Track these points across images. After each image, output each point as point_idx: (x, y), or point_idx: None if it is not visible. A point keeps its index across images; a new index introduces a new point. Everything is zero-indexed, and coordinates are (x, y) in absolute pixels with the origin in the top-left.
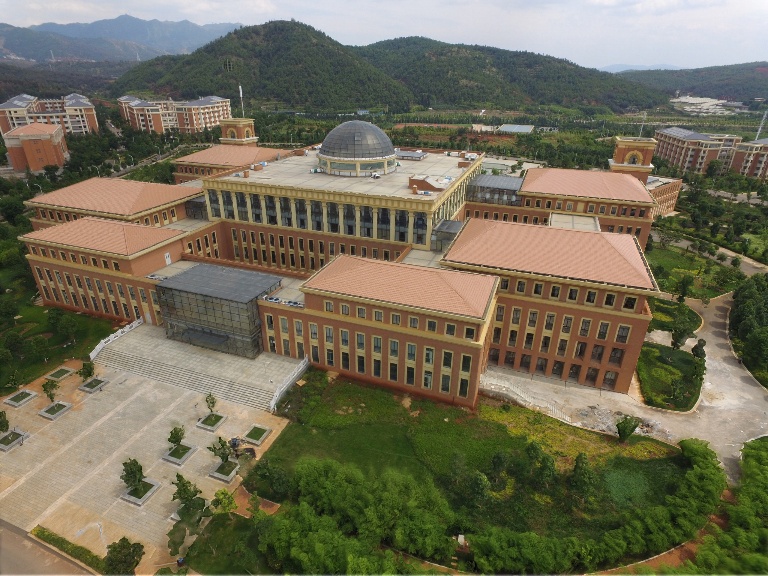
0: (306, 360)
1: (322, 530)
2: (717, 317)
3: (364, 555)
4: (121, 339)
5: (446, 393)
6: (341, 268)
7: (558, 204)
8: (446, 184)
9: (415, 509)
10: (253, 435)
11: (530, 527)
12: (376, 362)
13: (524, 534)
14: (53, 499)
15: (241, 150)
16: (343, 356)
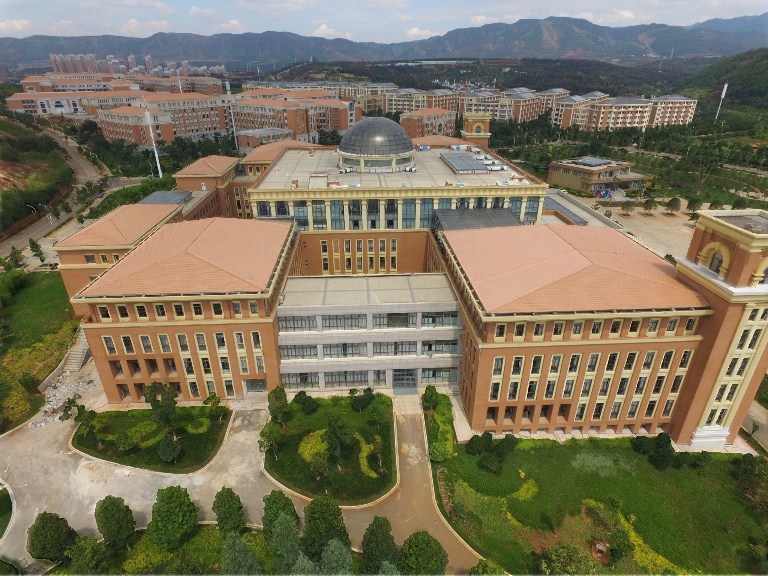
0: None
1: None
2: None
3: None
4: None
5: None
6: None
7: None
8: None
9: None
10: None
11: None
12: None
13: None
14: (42, 245)
15: (431, 141)
16: None
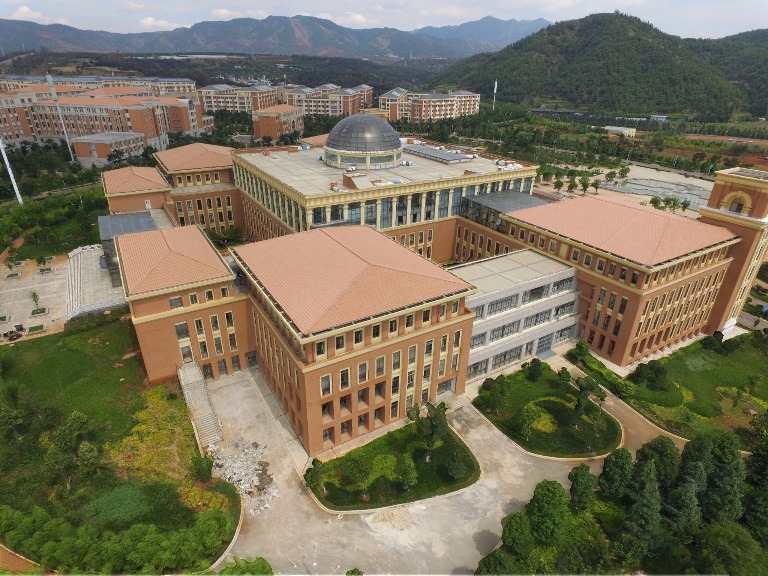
0: None
1: None
2: None
3: None
4: (94, 251)
5: None
6: None
7: (542, 240)
8: (378, 186)
9: None
10: (33, 328)
11: (10, 471)
12: None
13: None
14: None
15: None
16: None
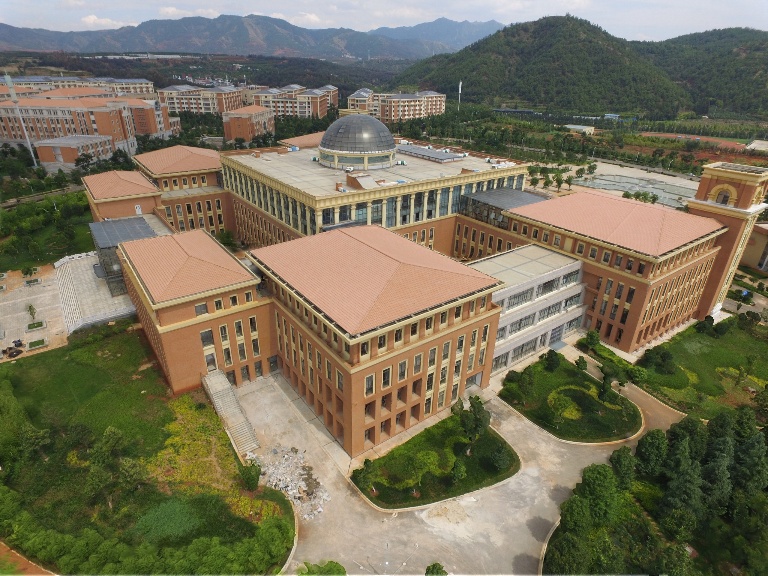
0: (133, 309)
1: None
2: None
3: None
4: (82, 259)
5: None
6: None
7: (546, 235)
8: (384, 186)
9: None
10: (33, 344)
11: (43, 494)
12: None
13: (0, 487)
14: None
15: None
16: None
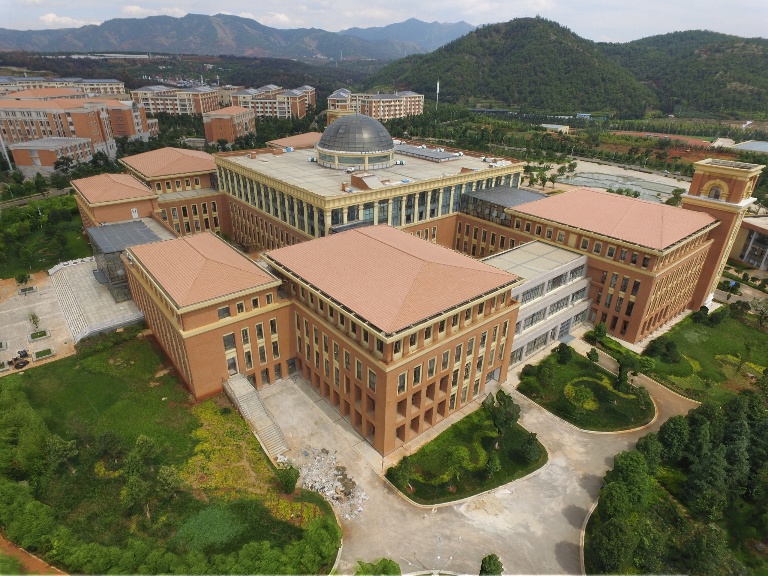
0: (141, 314)
1: None
2: None
3: None
4: (77, 266)
5: None
6: None
7: (549, 231)
8: (389, 186)
9: (2, 442)
10: (40, 353)
11: (76, 507)
12: None
13: (33, 502)
14: None
15: None
16: None
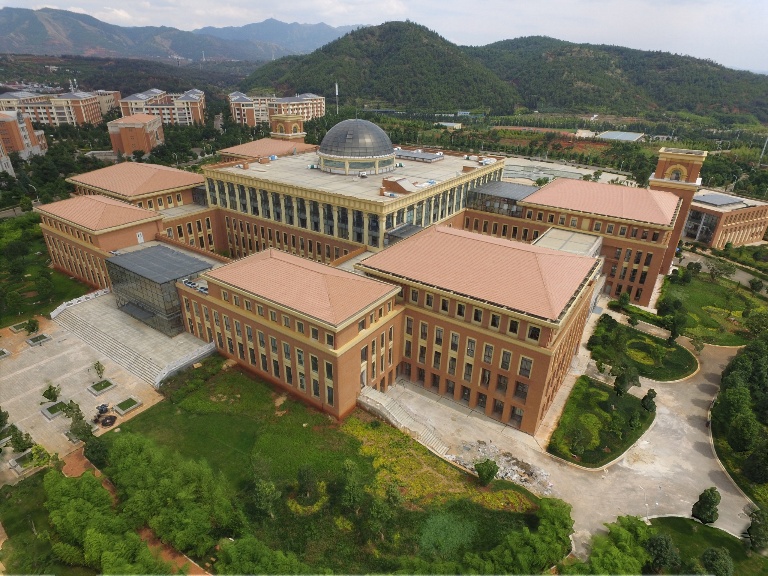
0: (213, 345)
1: (83, 500)
2: (721, 369)
3: (108, 532)
4: (83, 304)
5: (317, 398)
6: (249, 260)
7: (562, 218)
8: (422, 188)
9: (189, 502)
10: (123, 405)
11: (306, 548)
12: (263, 356)
13: (275, 552)
14: None
15: (278, 144)
16: (240, 346)
